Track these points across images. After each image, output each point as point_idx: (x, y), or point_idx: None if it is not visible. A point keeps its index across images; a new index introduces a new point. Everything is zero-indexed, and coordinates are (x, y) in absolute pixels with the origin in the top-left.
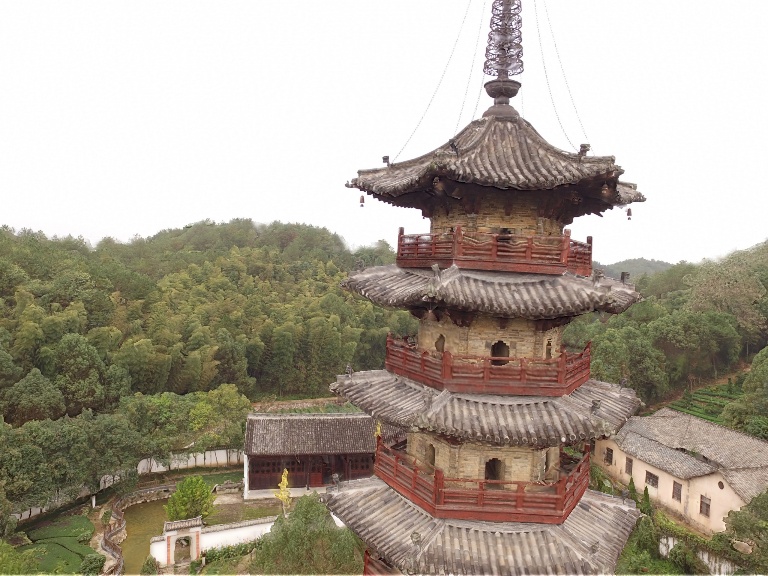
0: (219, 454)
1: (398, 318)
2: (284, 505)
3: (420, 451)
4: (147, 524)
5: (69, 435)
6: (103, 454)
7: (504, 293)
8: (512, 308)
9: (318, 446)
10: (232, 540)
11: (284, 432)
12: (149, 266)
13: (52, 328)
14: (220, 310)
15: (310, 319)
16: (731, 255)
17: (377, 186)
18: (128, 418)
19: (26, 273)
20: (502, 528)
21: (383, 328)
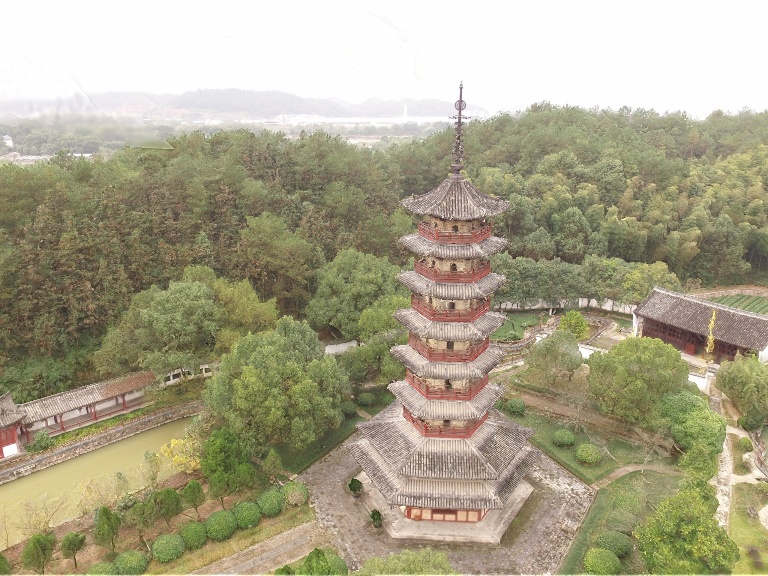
0: None
1: None
2: None
3: None
4: None
5: (538, 270)
6: None
7: None
8: None
9: (686, 323)
10: None
11: (671, 306)
12: (737, 142)
13: (564, 202)
14: (748, 196)
15: None
16: None
17: None
18: (583, 269)
19: (580, 159)
20: None
21: None
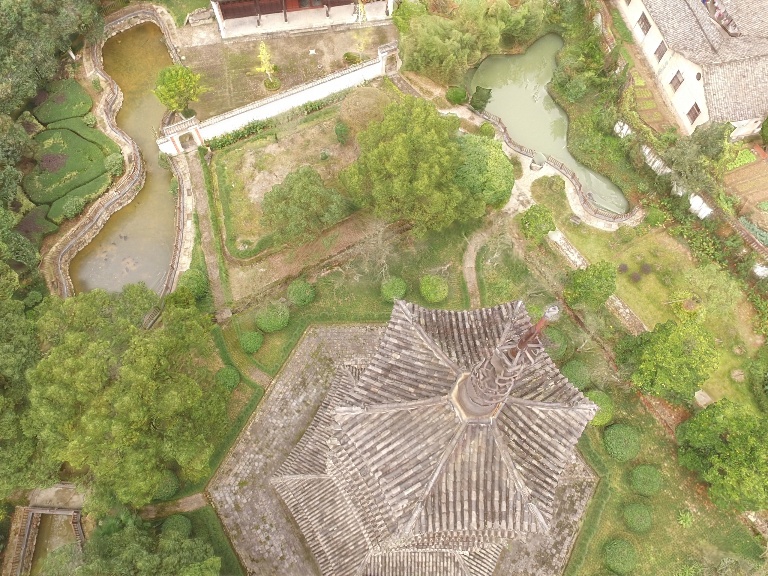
0: None
1: None
2: (267, 70)
3: None
4: (135, 73)
5: (12, 11)
6: (57, 13)
7: None
8: (454, 536)
9: None
10: (229, 129)
11: None
12: None
13: None
14: None
15: None
16: None
17: None
18: None
19: None
20: None
21: None
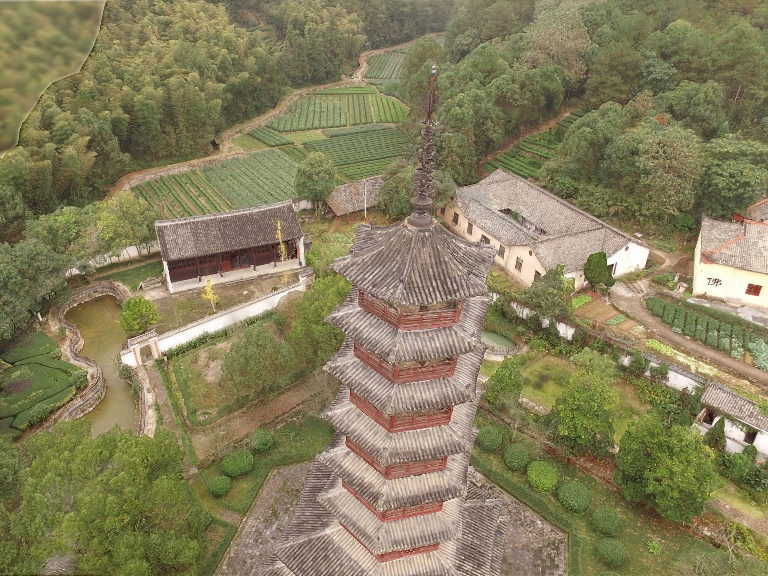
0: (129, 250)
1: (255, 60)
2: (212, 301)
3: None
4: (95, 326)
5: (2, 274)
6: (36, 280)
7: (426, 341)
8: (432, 358)
9: (226, 244)
10: (183, 340)
11: (192, 235)
12: None
13: None
14: (67, 79)
15: (168, 79)
16: None
17: (350, 278)
18: (42, 241)
19: None
20: (421, 429)
21: (242, 74)
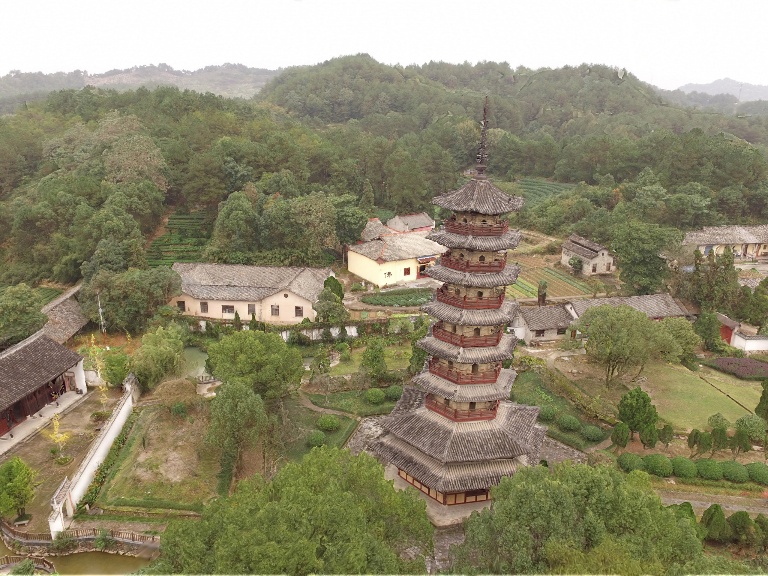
0: None
1: None
2: (61, 445)
3: (474, 295)
4: None
5: None
6: None
7: None
8: None
9: (15, 392)
10: (90, 481)
11: None
12: None
13: None
14: None
15: None
16: (23, 108)
17: (482, 211)
18: None
19: None
20: None
21: None
